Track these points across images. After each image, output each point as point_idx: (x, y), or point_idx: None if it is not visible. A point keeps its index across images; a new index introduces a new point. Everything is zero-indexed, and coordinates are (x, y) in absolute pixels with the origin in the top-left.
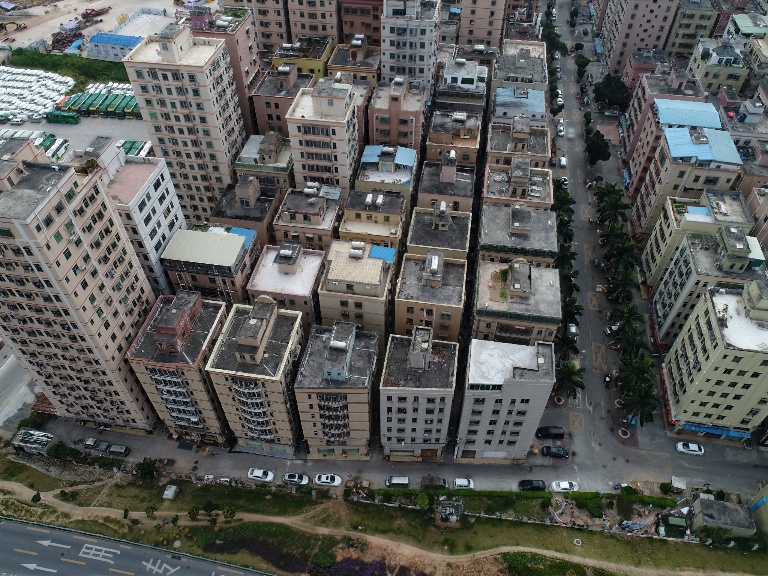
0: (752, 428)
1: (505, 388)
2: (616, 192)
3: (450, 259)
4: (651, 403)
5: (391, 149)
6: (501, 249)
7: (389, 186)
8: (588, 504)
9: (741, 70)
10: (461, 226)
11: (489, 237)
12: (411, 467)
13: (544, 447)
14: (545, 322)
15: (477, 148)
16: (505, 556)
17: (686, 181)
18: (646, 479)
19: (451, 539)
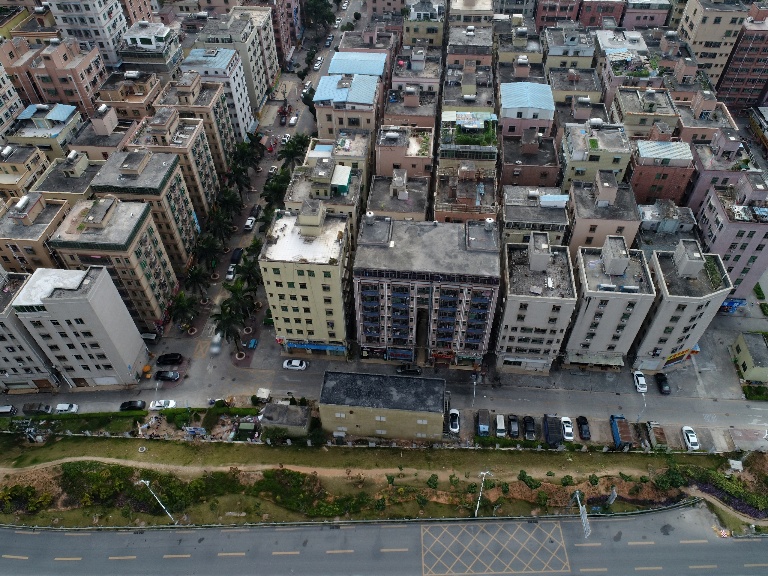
0: (343, 341)
1: (48, 308)
2: (304, 142)
3: (52, 200)
4: (236, 322)
5: (44, 106)
6: (109, 189)
7: (38, 140)
8: (175, 418)
9: (436, 24)
10: (94, 173)
11: (100, 179)
12: (25, 398)
13: (156, 372)
14: (113, 249)
15: (142, 103)
16: (64, 465)
17: (335, 124)
18: (244, 394)
19: (25, 455)
